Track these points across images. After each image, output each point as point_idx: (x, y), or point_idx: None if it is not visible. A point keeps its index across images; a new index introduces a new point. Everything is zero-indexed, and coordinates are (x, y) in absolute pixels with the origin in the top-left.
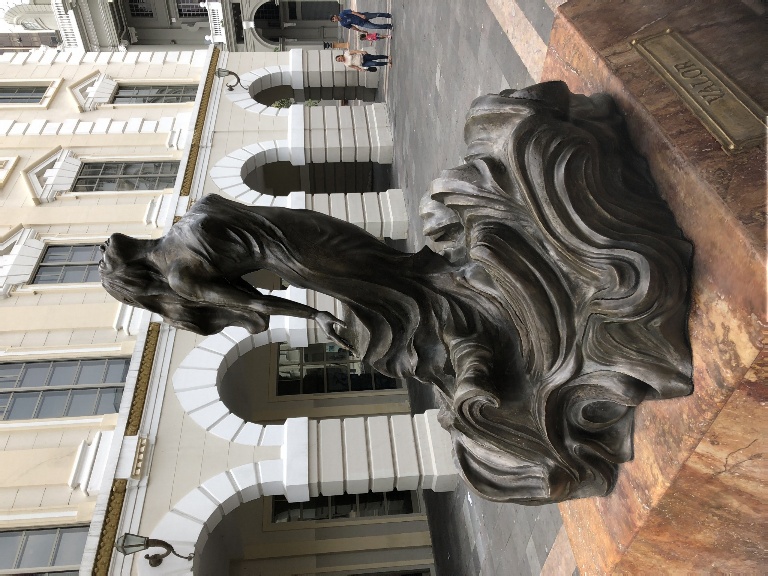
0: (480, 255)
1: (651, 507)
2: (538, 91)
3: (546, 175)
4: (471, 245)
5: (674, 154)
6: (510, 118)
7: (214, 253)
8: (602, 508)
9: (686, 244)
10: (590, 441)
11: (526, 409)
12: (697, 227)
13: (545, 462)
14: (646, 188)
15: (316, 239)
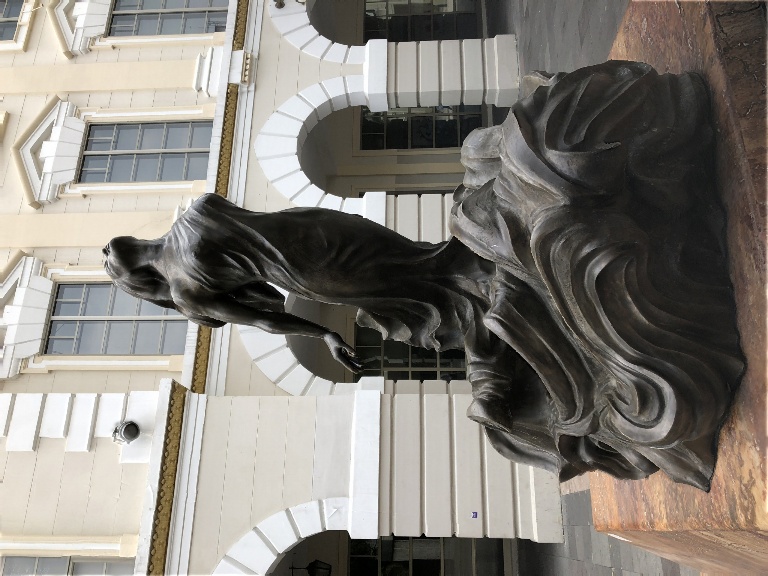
0: (493, 329)
1: (653, 529)
2: (580, 167)
3: (574, 277)
4: (491, 292)
5: (756, 242)
6: (541, 191)
7: (212, 279)
8: (617, 482)
9: (737, 362)
10: (605, 458)
11: (543, 424)
12: (755, 352)
13: (560, 455)
14: (713, 260)
15: (322, 259)
